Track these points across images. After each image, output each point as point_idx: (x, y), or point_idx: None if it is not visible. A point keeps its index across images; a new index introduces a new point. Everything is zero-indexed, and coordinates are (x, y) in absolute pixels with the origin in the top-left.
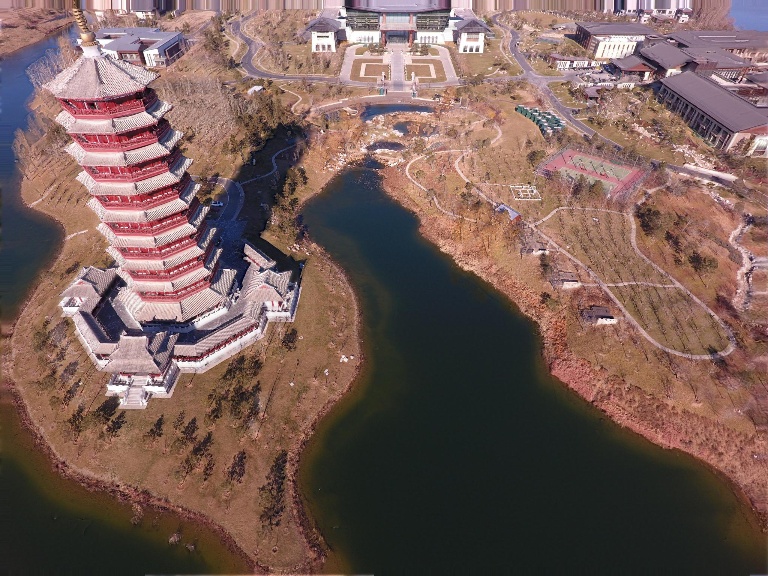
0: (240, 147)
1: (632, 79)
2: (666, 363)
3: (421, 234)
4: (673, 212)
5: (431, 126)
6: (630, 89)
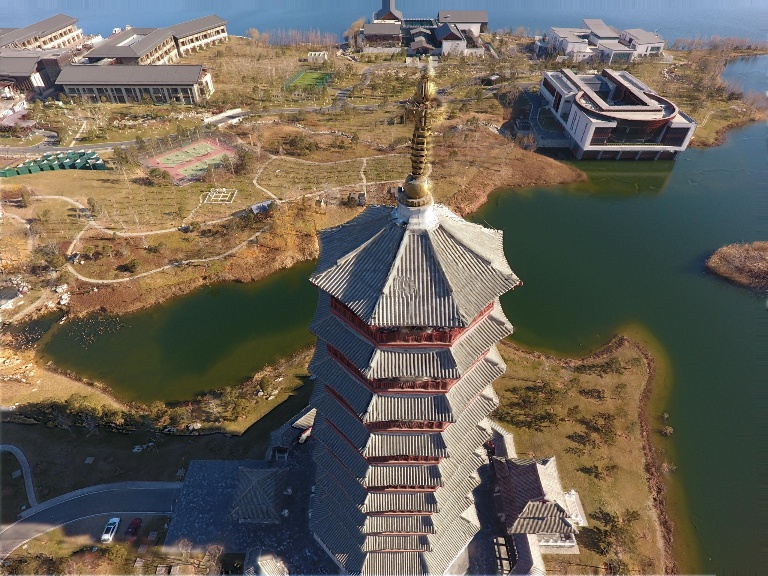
0: None
1: (20, 96)
2: (439, 178)
3: (253, 281)
4: (275, 140)
5: None
6: (24, 107)
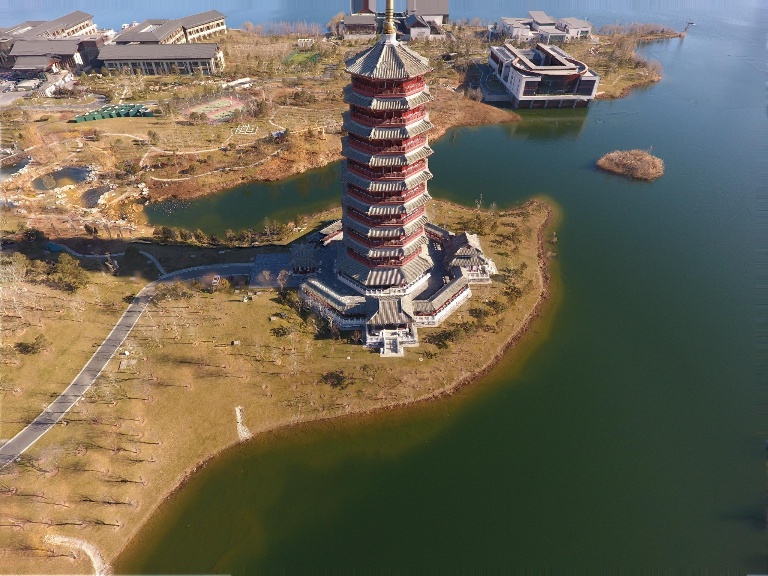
0: (58, 282)
1: (69, 70)
2: None
3: (278, 180)
4: None
5: (58, 170)
6: (71, 79)
